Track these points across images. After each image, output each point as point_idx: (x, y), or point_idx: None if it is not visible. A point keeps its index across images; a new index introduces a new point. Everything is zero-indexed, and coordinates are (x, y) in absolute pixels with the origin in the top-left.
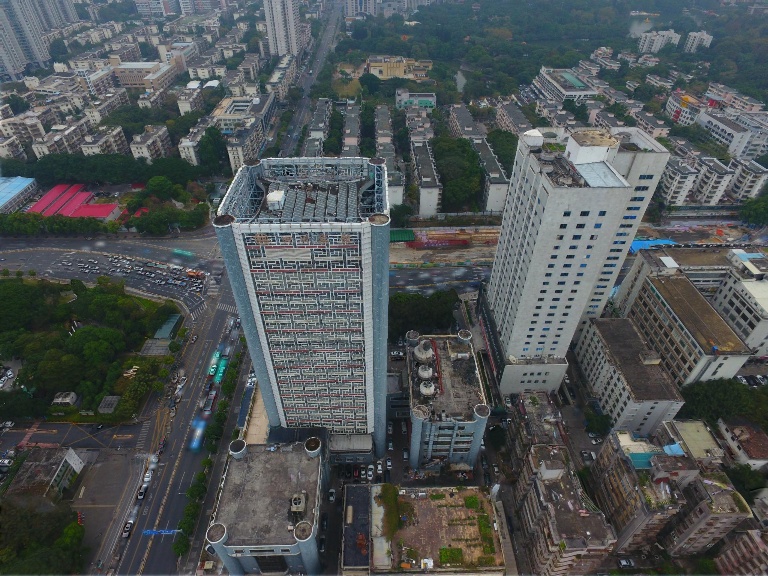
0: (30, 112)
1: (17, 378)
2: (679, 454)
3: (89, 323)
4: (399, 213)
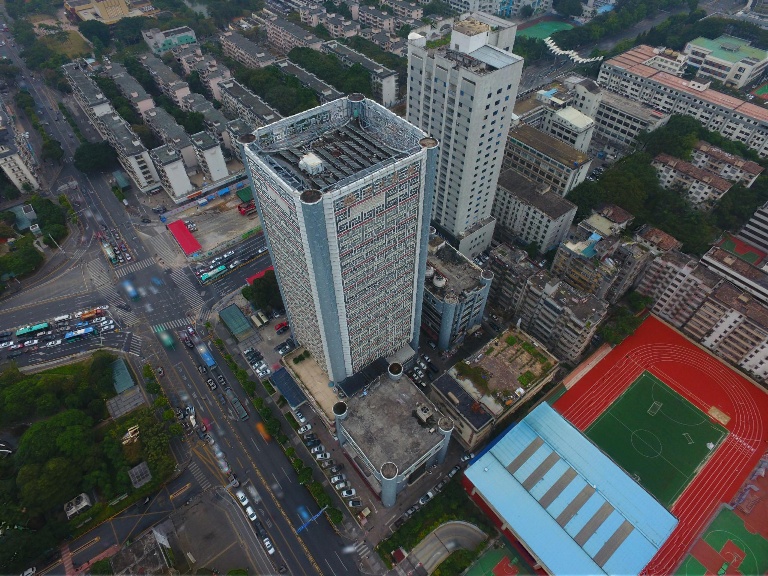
0: None
1: (1, 523)
2: (599, 238)
3: (0, 431)
4: None
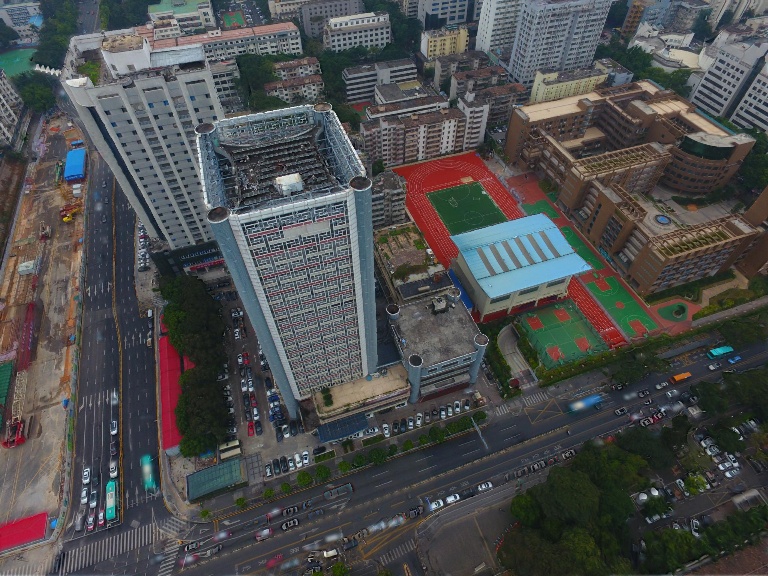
0: None
1: None
2: None
3: None
4: None
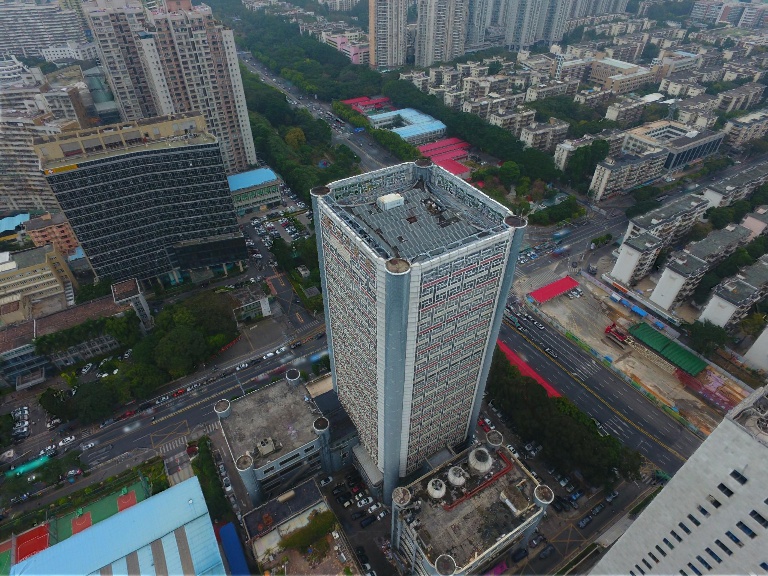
0: (492, 77)
1: (296, 240)
2: None
3: None
4: (703, 333)
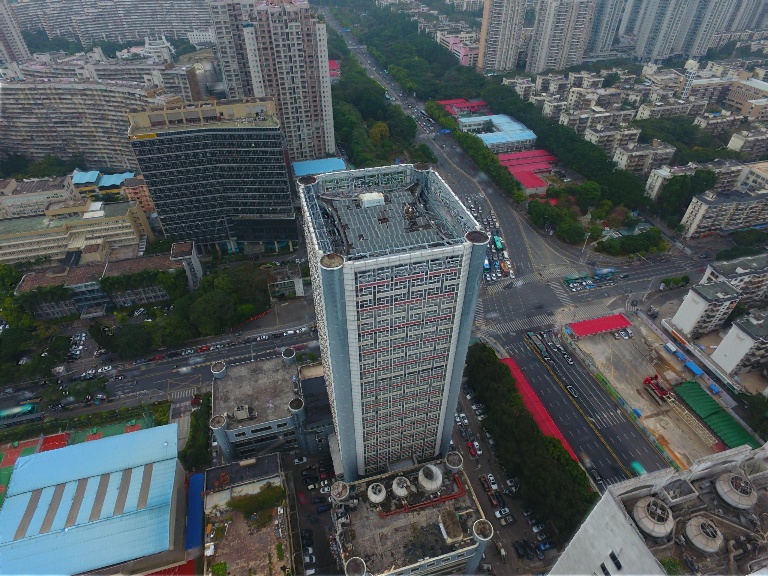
0: (603, 90)
1: None
2: None
3: None
4: (761, 408)
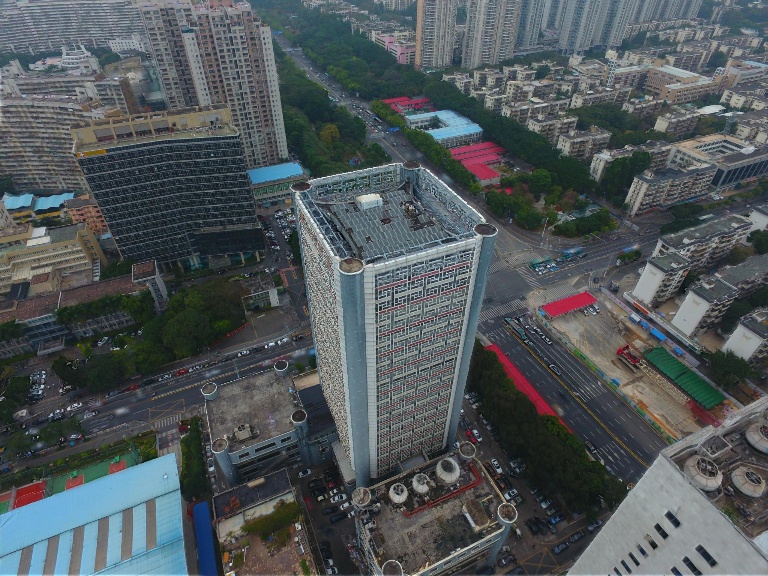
0: (537, 82)
1: None
2: None
3: None
4: (723, 364)
